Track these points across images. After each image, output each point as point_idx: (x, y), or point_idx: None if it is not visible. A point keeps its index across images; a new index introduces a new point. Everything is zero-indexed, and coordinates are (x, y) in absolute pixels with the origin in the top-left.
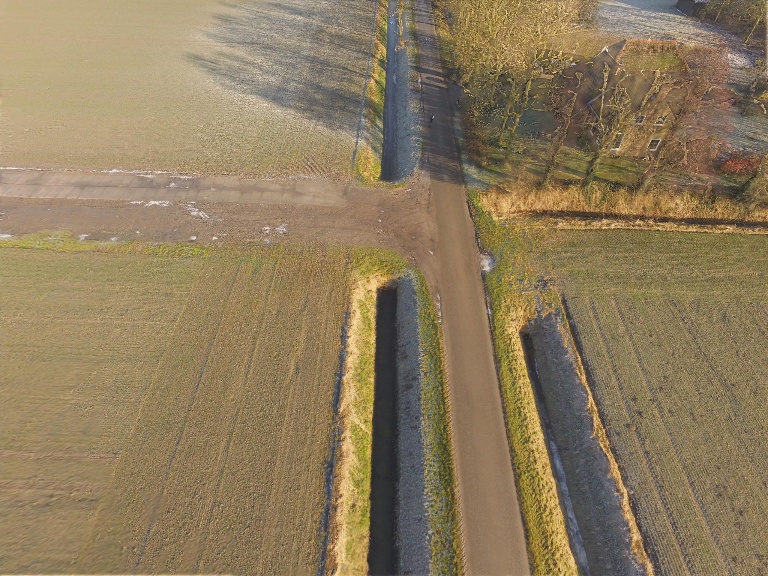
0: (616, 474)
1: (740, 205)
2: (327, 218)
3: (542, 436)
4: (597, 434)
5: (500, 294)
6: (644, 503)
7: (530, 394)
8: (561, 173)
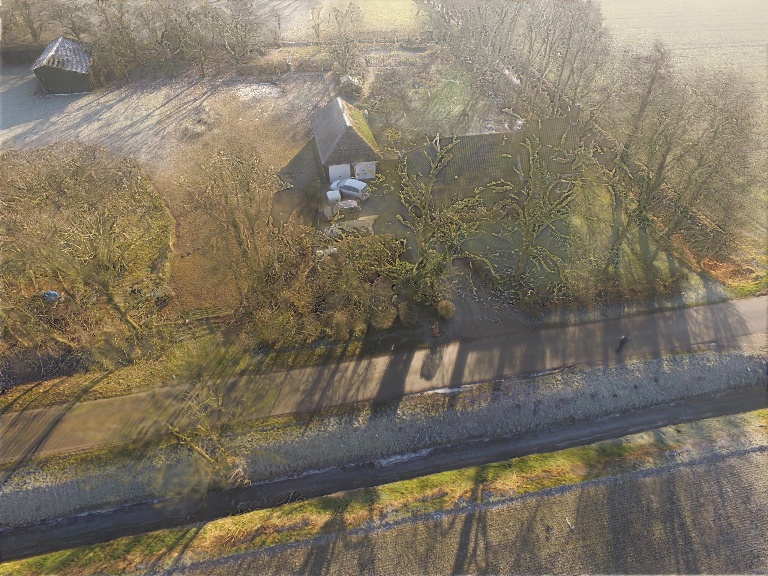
0: None
1: None
2: None
3: None
4: None
5: None
6: None
7: None
8: None
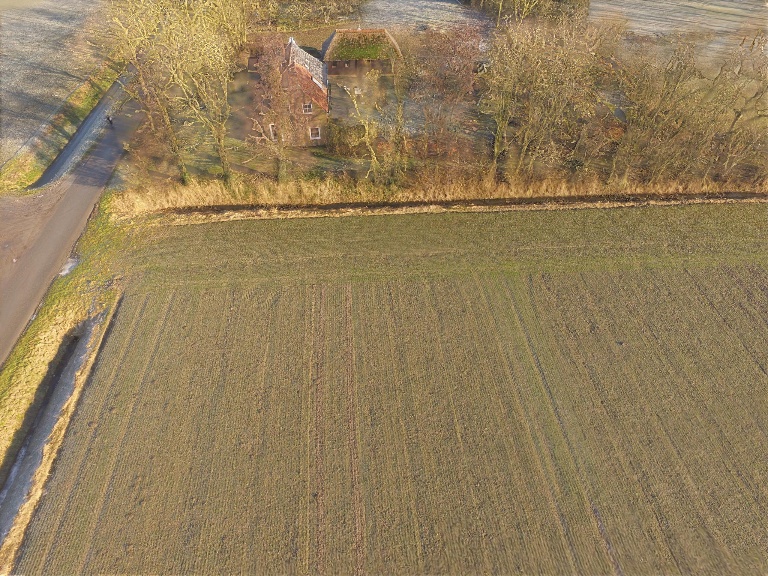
0: (40, 476)
1: (382, 187)
2: None
3: (7, 444)
4: (52, 436)
5: (56, 298)
6: (48, 504)
7: (22, 400)
8: (217, 168)
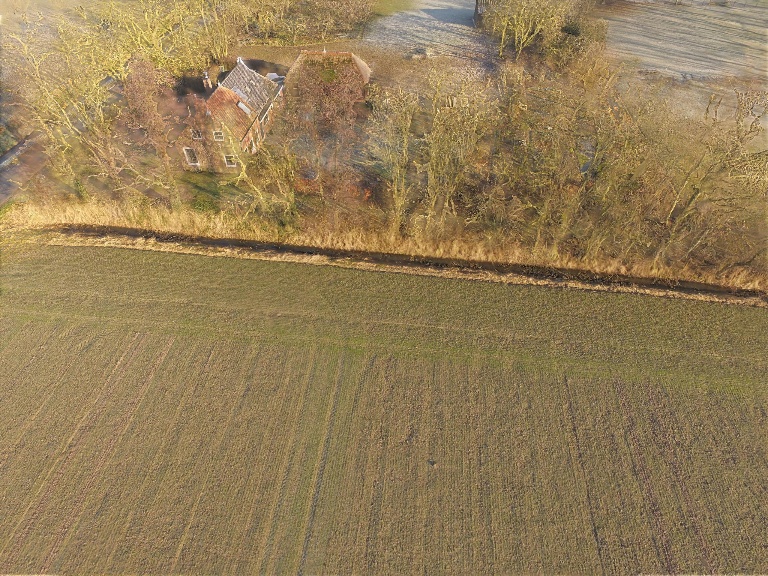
0: None
1: (277, 227)
2: None
3: None
4: None
5: None
6: None
7: None
8: None
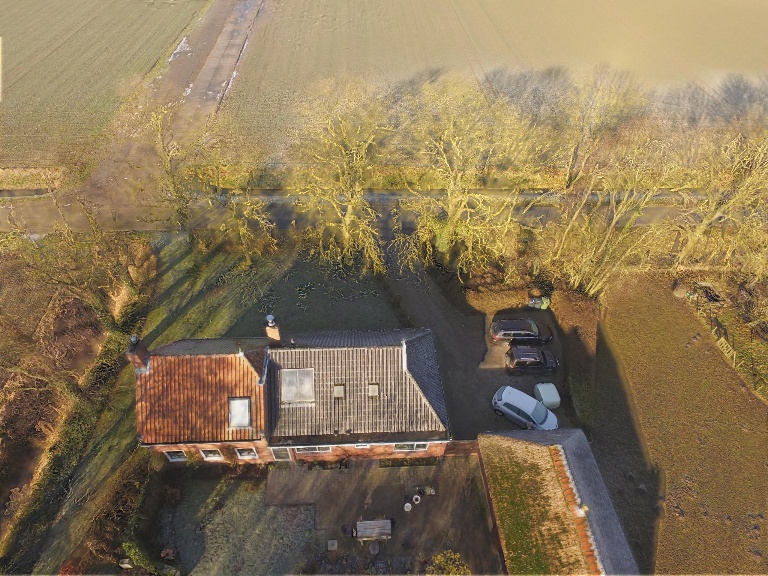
0: None
1: None
2: (140, 153)
3: None
4: None
5: None
6: None
7: None
8: (161, 316)
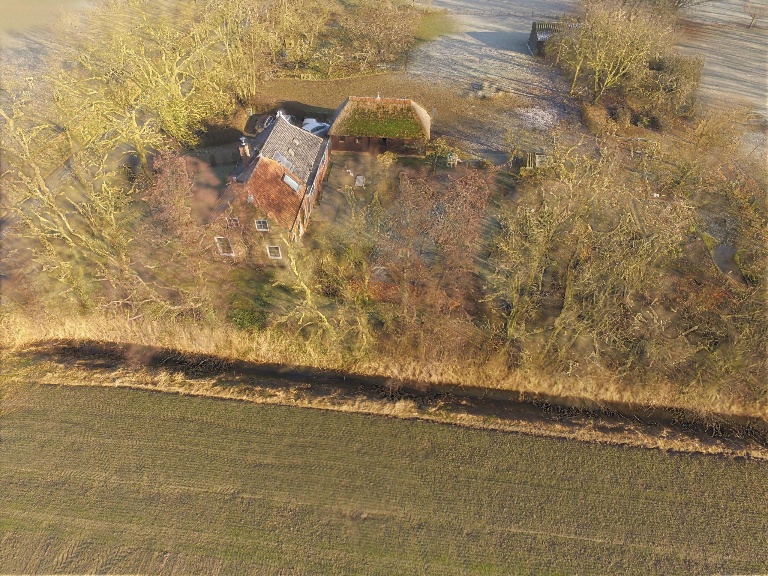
0: None
1: (341, 351)
2: None
3: None
4: None
5: None
6: None
7: None
8: None
